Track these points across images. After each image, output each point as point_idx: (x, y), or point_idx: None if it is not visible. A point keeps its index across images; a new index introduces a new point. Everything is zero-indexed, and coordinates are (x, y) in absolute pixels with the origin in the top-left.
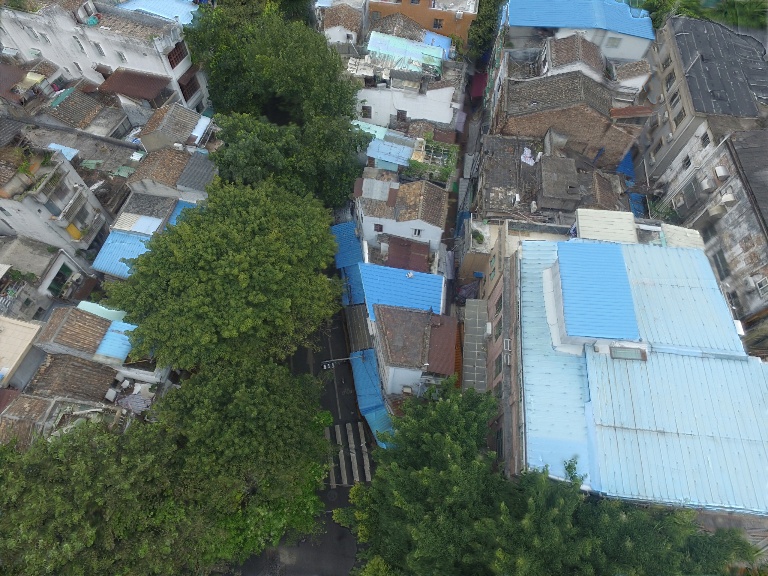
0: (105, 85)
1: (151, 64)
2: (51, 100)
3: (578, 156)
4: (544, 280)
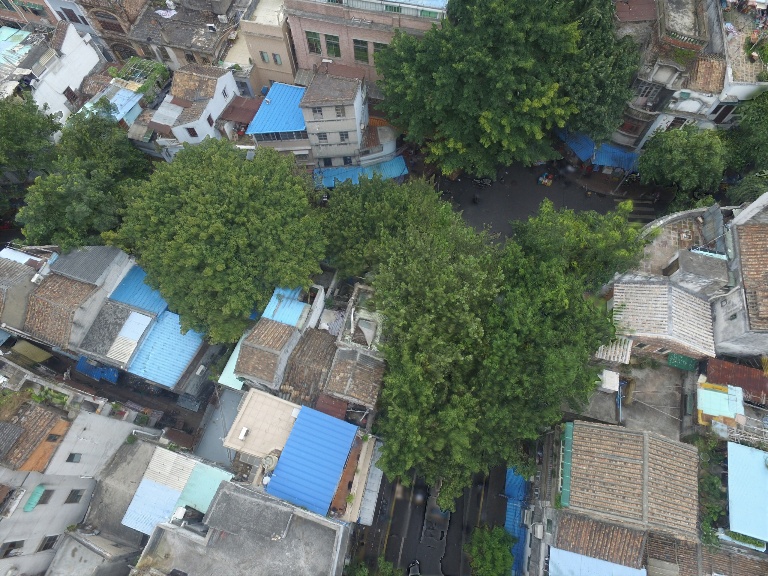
0: None
1: None
2: None
3: None
4: None
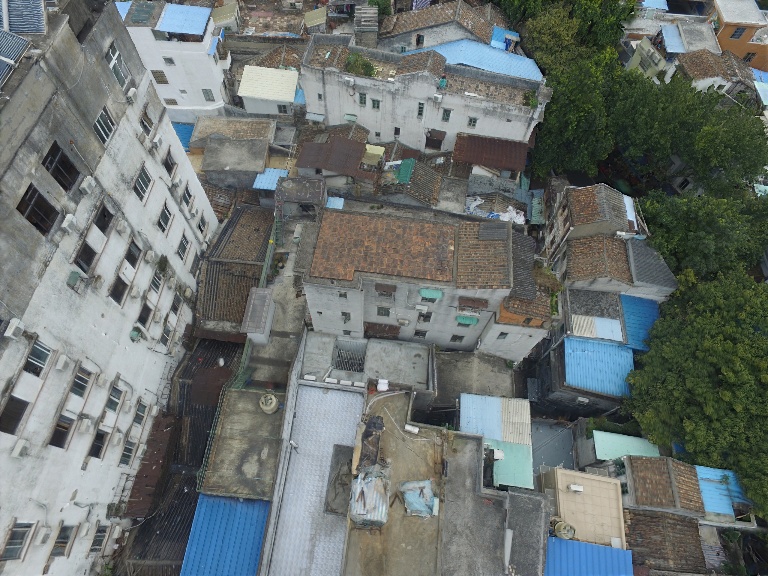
0: (458, 156)
1: (508, 130)
2: (390, 174)
3: None
4: None
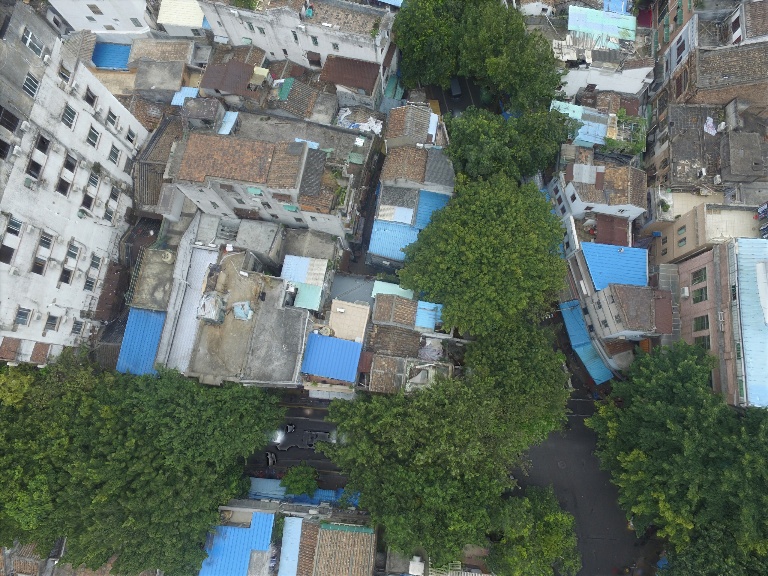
0: (324, 76)
1: (363, 53)
2: (275, 91)
3: (753, 118)
4: (758, 272)
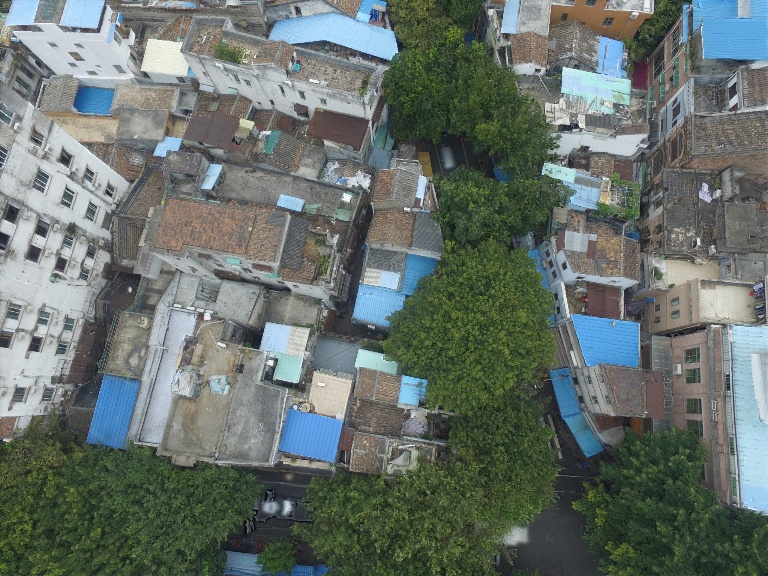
0: (311, 131)
1: (351, 109)
2: (261, 144)
3: (749, 184)
4: (752, 363)
